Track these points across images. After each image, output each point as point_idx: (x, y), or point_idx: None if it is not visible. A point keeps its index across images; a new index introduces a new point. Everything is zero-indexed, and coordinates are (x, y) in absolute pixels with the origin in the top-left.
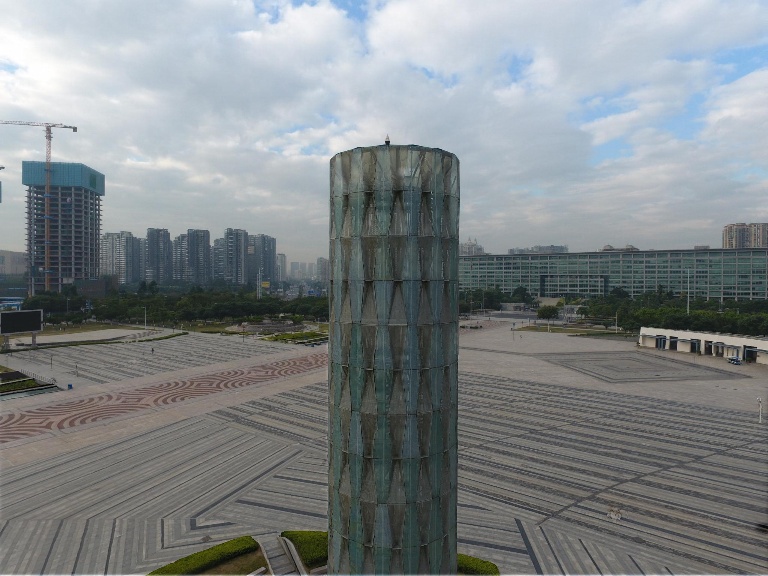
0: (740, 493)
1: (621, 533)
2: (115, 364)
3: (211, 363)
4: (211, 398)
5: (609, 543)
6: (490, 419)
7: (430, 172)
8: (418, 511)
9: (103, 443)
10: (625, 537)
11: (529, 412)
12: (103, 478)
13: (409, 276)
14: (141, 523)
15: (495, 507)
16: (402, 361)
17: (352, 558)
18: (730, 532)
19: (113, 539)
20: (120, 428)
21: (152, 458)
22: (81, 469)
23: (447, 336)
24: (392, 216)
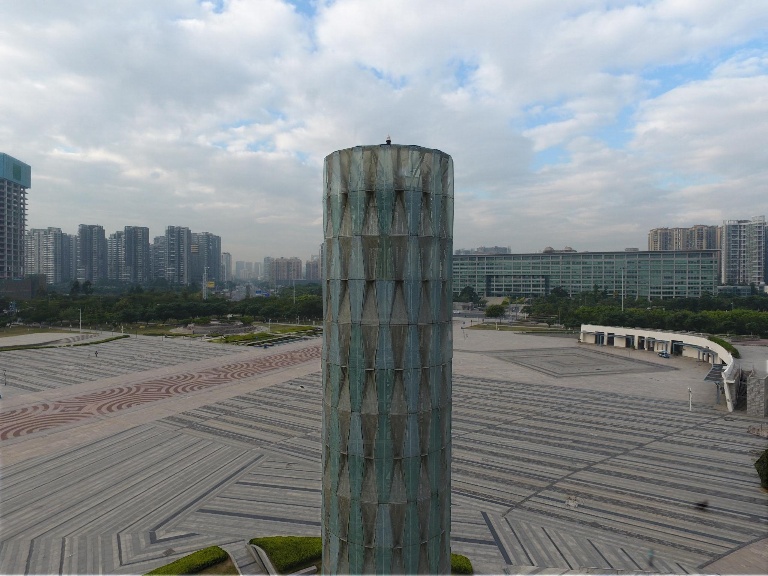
0: (679, 476)
1: (579, 519)
2: (49, 371)
3: (158, 367)
4: (161, 404)
5: (569, 529)
6: None
7: (430, 173)
8: (418, 509)
9: (42, 456)
10: (583, 523)
11: (485, 408)
12: (46, 494)
13: (410, 276)
14: (94, 540)
15: (461, 501)
16: (403, 360)
17: (351, 560)
18: (674, 512)
19: (64, 559)
20: (61, 439)
21: (100, 470)
22: (19, 486)
23: (444, 335)
24: (393, 216)
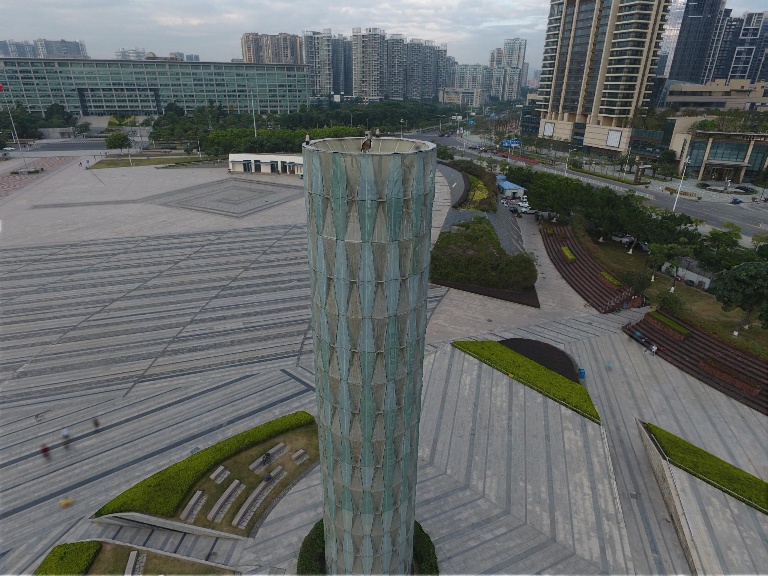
0: None
1: None
2: None
3: None
4: None
5: None
6: (174, 289)
7: None
8: None
9: None
10: None
11: (202, 269)
12: None
13: None
14: None
15: (259, 369)
16: None
17: (384, 475)
18: None
19: None
20: None
21: None
22: None
23: None
24: (421, 218)
